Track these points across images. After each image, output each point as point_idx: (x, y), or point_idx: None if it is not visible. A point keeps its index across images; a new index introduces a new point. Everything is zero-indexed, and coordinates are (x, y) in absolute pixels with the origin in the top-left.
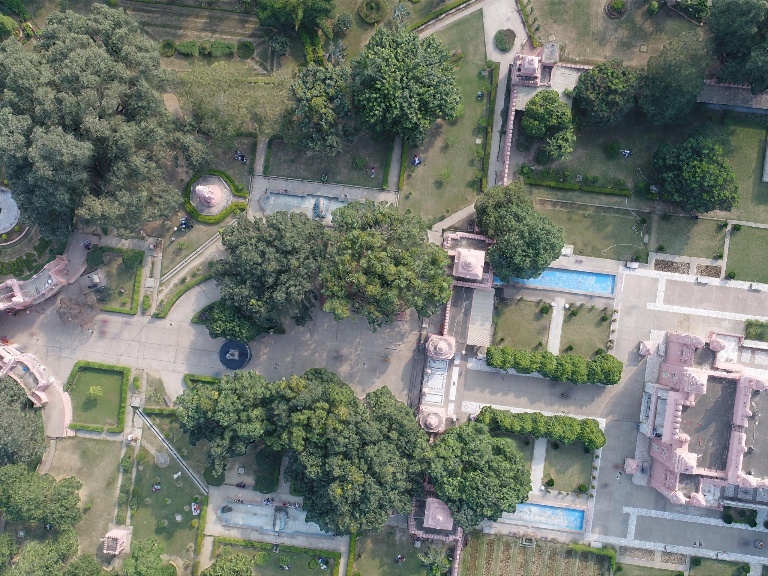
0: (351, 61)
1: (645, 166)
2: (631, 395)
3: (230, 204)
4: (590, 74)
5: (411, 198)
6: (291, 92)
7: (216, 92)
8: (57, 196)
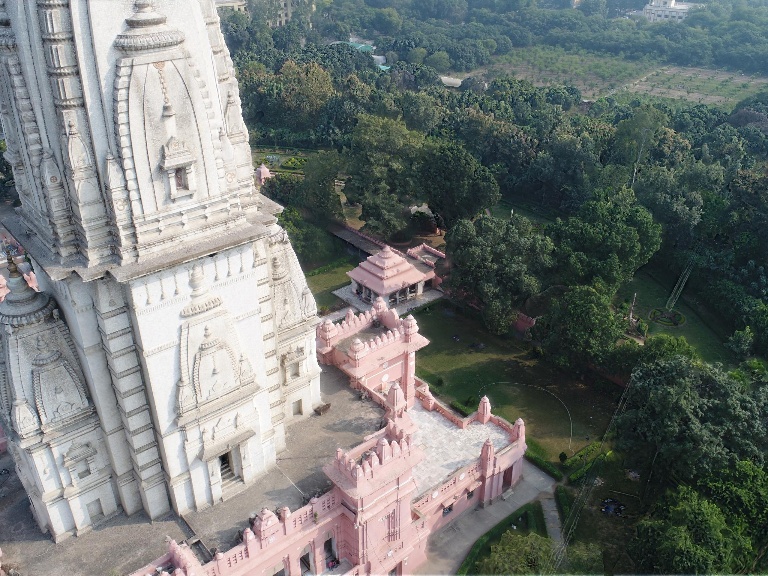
0: None
1: None
2: None
3: None
4: None
5: None
6: None
7: None
8: None
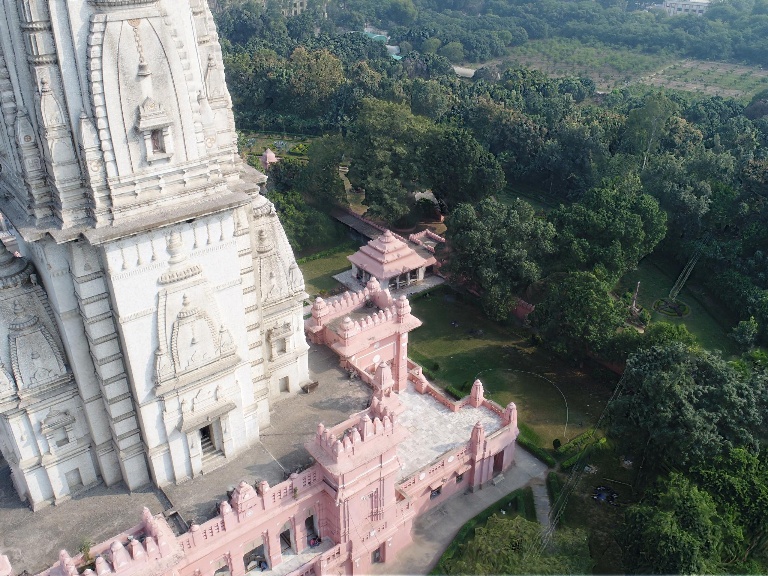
0: None
1: None
2: None
3: None
4: None
5: None
6: None
7: None
8: None
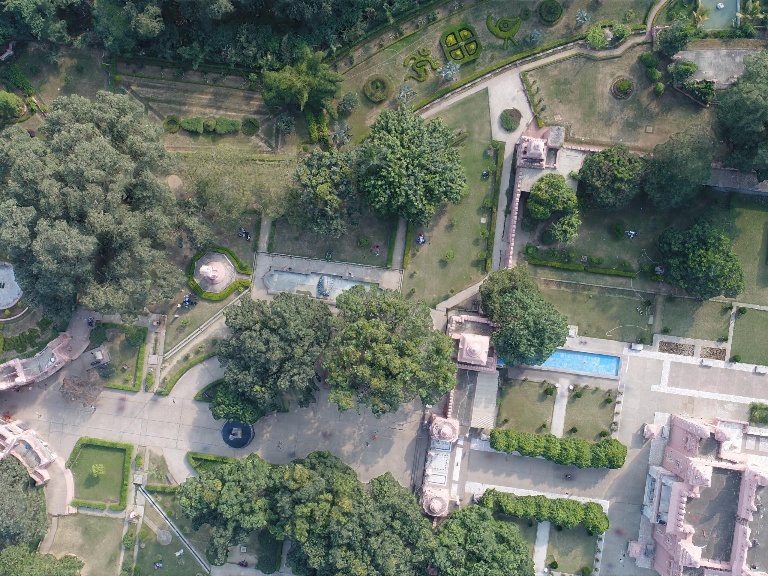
0: (357, 150)
1: (650, 247)
2: (635, 477)
3: (234, 281)
4: (596, 160)
5: (415, 277)
6: (296, 177)
7: (221, 176)
8: (61, 287)
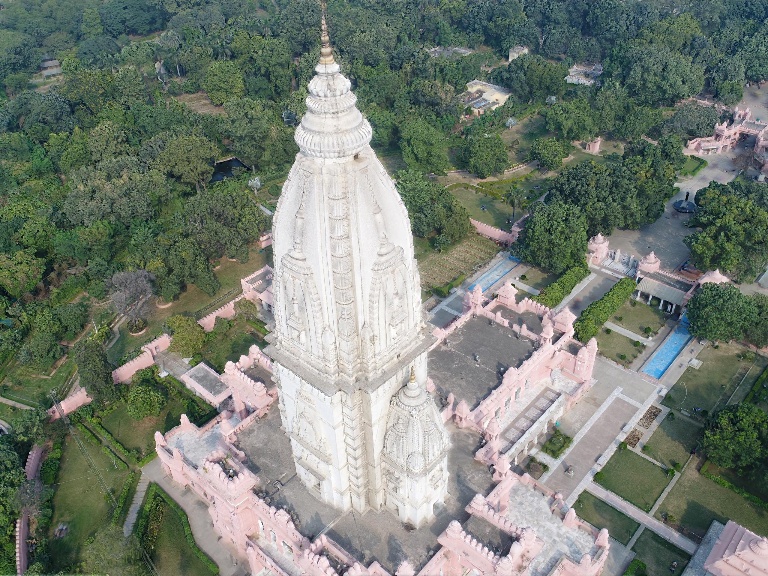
0: None
1: None
2: None
3: None
4: None
5: None
6: None
7: None
8: None
